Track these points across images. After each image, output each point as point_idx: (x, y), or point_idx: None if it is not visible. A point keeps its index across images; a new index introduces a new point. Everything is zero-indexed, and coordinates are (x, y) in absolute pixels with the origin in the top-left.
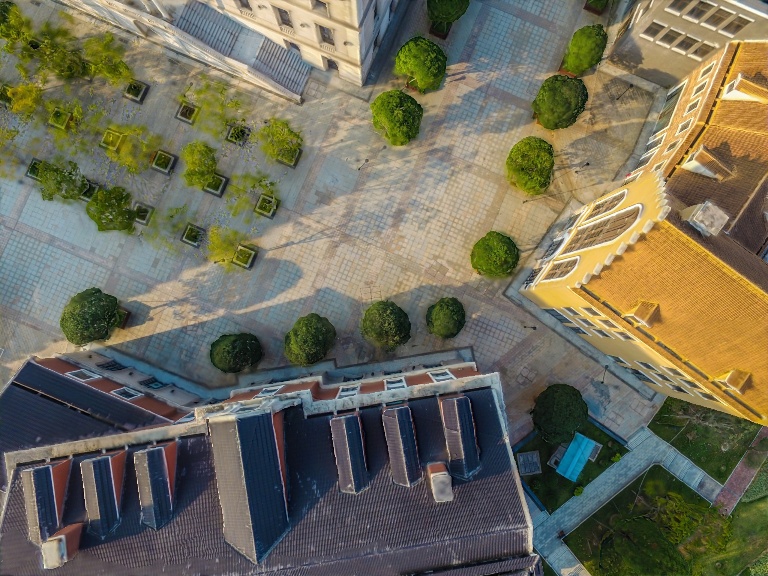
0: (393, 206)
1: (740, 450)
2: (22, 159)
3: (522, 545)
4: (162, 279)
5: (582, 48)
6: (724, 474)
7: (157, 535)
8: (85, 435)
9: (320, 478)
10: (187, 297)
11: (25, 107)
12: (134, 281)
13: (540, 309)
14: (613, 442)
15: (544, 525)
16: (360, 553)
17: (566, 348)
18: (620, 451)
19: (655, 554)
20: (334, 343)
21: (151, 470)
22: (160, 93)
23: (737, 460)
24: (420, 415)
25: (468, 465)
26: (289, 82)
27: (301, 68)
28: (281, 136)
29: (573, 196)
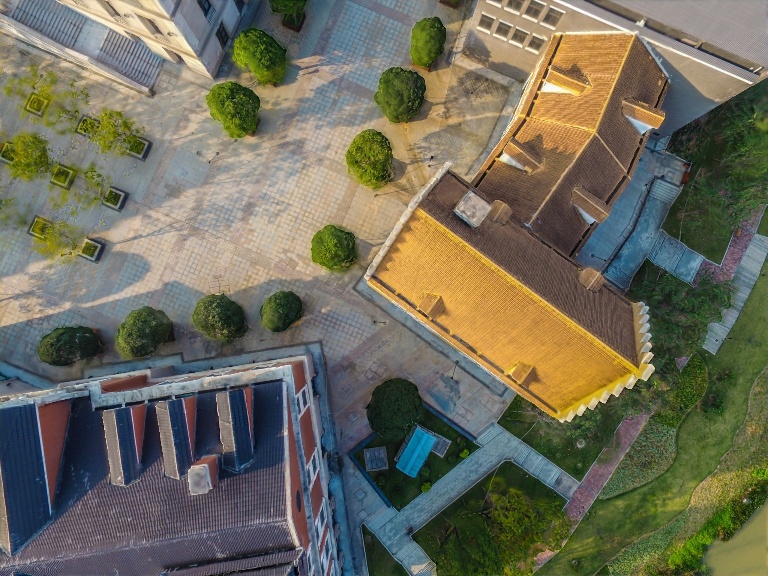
0: (243, 199)
1: (597, 447)
2: None
3: (286, 539)
4: (8, 272)
5: (419, 40)
6: (581, 471)
7: None
8: None
9: (93, 470)
10: (33, 290)
11: None
12: None
13: (390, 304)
14: (461, 438)
15: (393, 521)
16: (116, 546)
17: (416, 343)
18: (469, 447)
19: (471, 550)
20: (181, 337)
21: None
22: (10, 85)
23: (594, 457)
24: (206, 407)
25: (240, 458)
26: (139, 74)
27: (152, 60)
28: (113, 128)
29: None
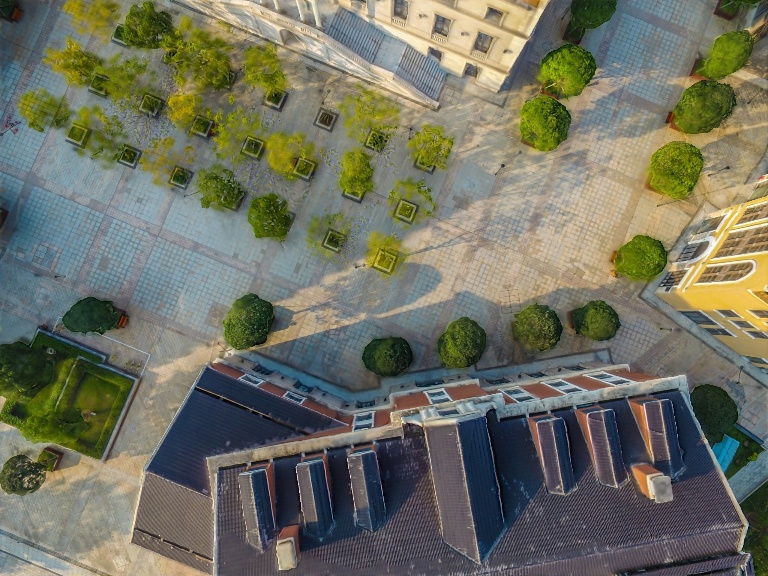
0: (530, 210)
1: None
2: (165, 167)
3: (733, 544)
4: (304, 284)
5: (729, 54)
6: None
7: (374, 537)
8: (270, 439)
9: (526, 480)
10: (329, 302)
11: (185, 116)
12: (277, 286)
13: (676, 311)
14: (750, 441)
15: None
16: (581, 553)
17: (701, 349)
18: (756, 450)
19: None
20: None
21: (366, 473)
22: (298, 100)
23: None
24: None
25: (673, 466)
26: (426, 89)
27: (437, 75)
28: (434, 143)
29: (706, 199)
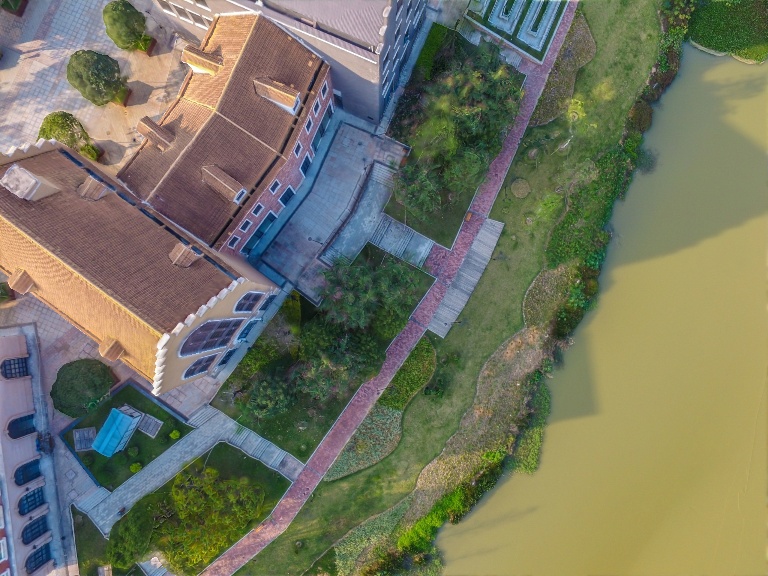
0: None
1: (322, 429)
2: None
3: None
4: None
5: None
6: (306, 453)
7: None
8: None
9: None
10: None
11: None
12: None
13: None
14: (170, 419)
15: (106, 502)
16: None
17: None
18: (180, 428)
19: None
20: None
21: None
22: None
23: (319, 439)
24: None
25: None
26: None
27: None
28: None
29: None
